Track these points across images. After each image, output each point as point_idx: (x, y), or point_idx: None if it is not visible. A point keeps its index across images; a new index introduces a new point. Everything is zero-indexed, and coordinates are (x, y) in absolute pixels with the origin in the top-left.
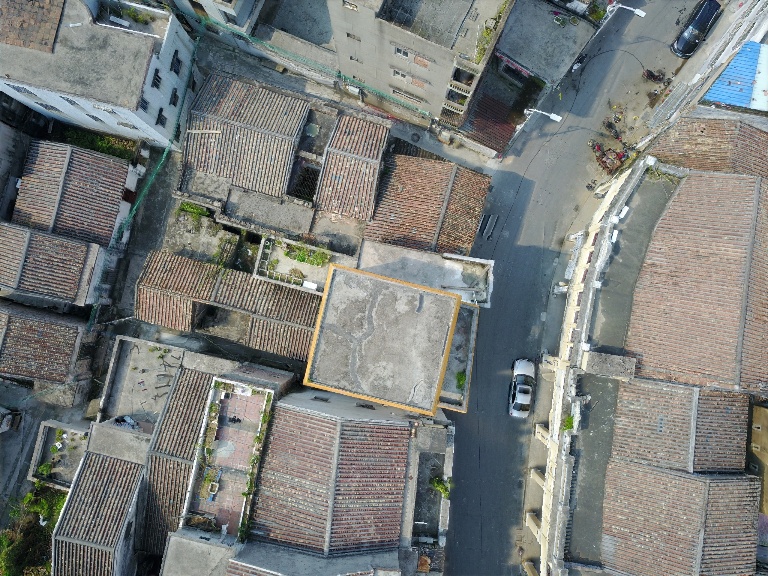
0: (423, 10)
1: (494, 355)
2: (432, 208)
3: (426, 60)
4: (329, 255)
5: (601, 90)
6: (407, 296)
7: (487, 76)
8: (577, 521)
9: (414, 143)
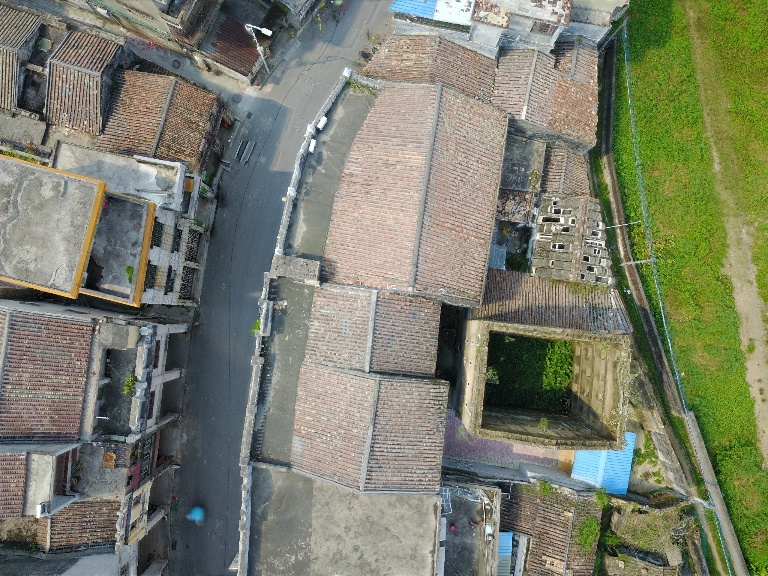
0: None
1: (247, 278)
2: (153, 121)
3: None
4: (39, 161)
5: (360, 21)
6: (52, 182)
7: (248, 5)
8: (270, 423)
9: (175, 69)
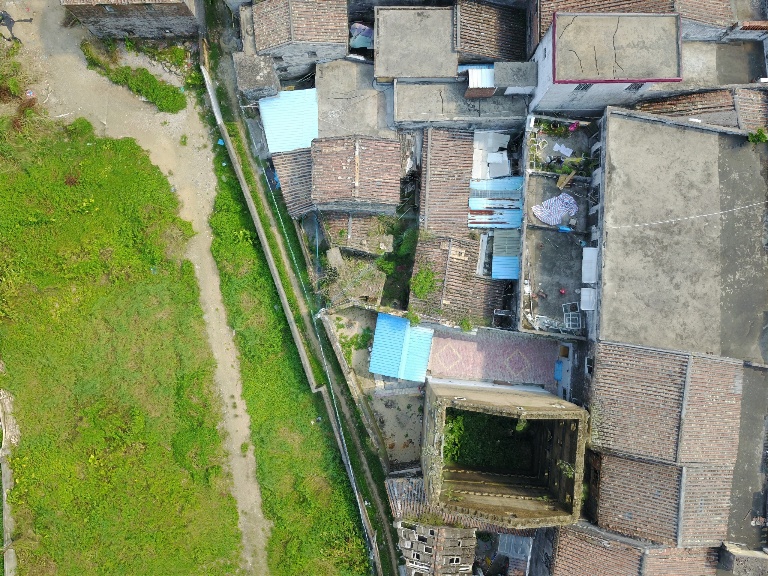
0: None
1: None
2: None
3: None
4: None
5: None
6: None
7: None
8: (764, 405)
9: None
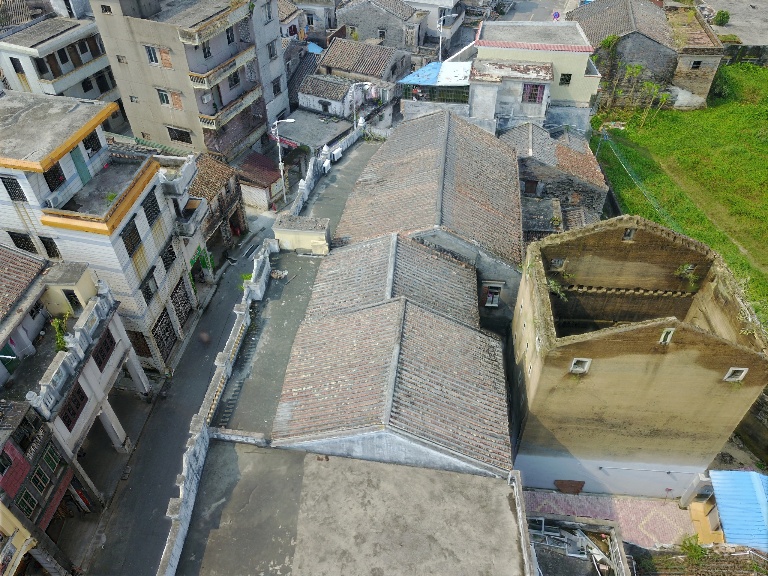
0: (166, 22)
1: None
2: None
3: (168, 55)
4: None
5: None
6: (64, 105)
7: None
8: (247, 392)
9: None
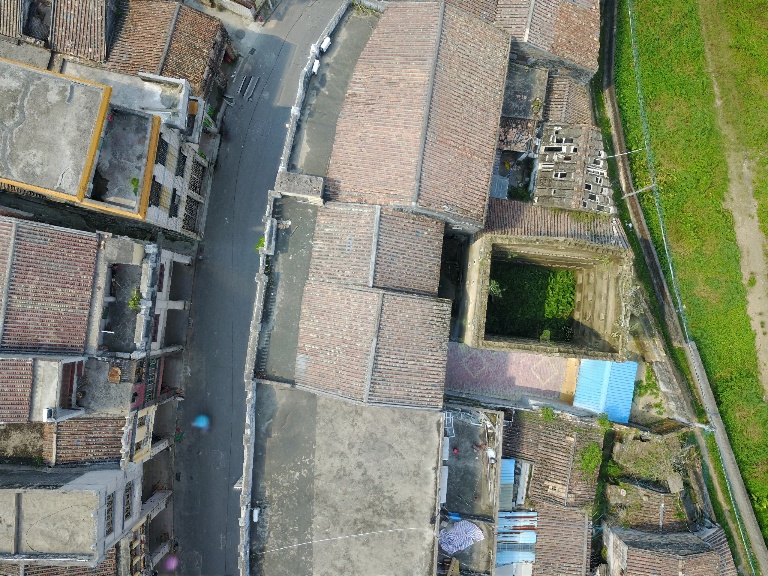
0: None
1: (250, 212)
2: (157, 46)
3: None
4: None
5: None
6: (58, 87)
7: None
8: (274, 341)
9: None
